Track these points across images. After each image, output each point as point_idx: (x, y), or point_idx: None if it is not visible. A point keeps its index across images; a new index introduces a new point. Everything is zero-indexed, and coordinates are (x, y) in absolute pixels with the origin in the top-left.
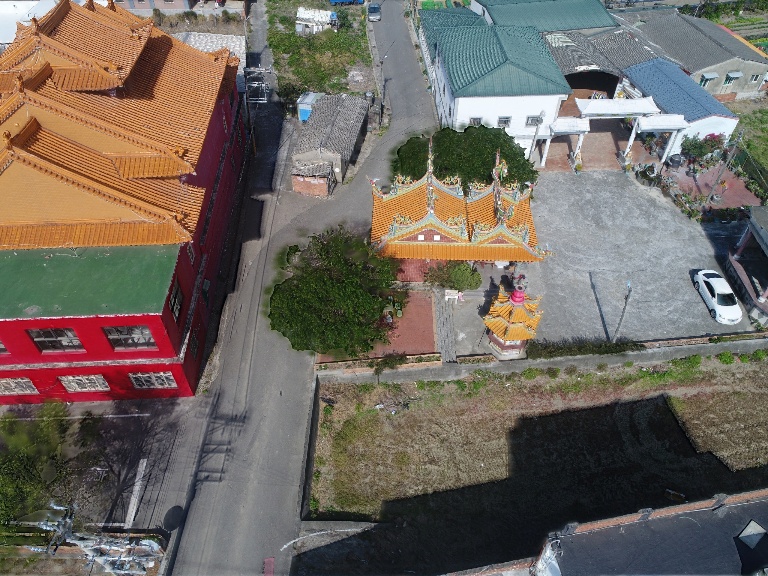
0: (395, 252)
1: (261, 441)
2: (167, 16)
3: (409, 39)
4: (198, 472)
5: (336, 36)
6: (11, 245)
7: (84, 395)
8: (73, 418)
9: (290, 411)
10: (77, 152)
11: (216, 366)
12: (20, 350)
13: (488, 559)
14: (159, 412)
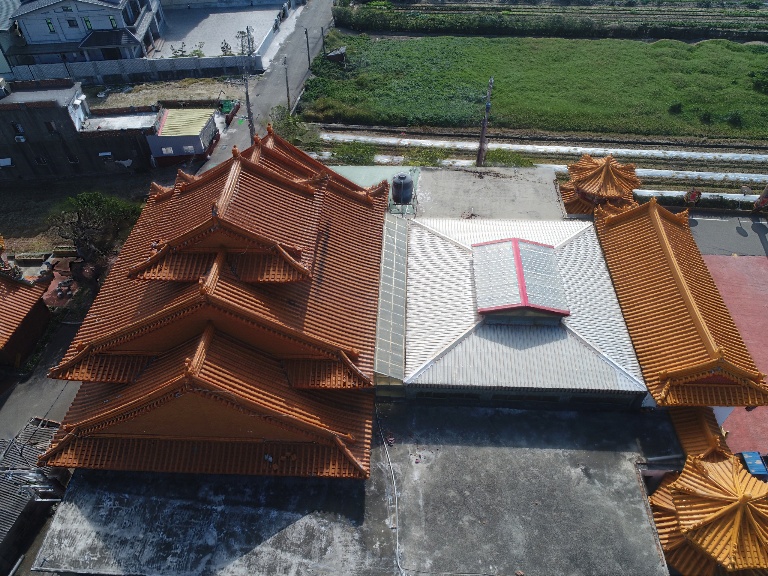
0: (30, 278)
1: None
2: None
3: None
4: None
5: None
6: None
7: None
8: None
9: None
10: None
11: None
12: None
13: (100, 186)
14: None
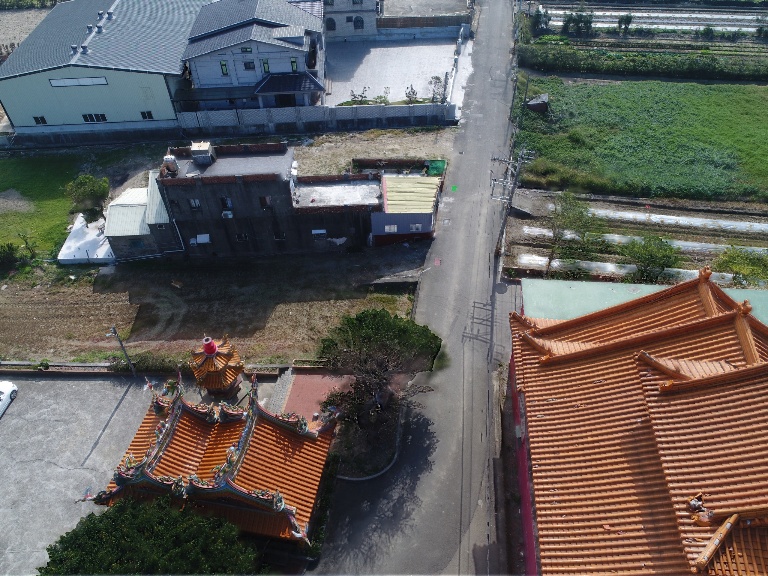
0: None
1: (448, 321)
2: None
3: None
4: (492, 310)
5: None
6: None
7: None
8: None
9: None
10: None
11: (495, 380)
12: None
13: (309, 268)
14: None
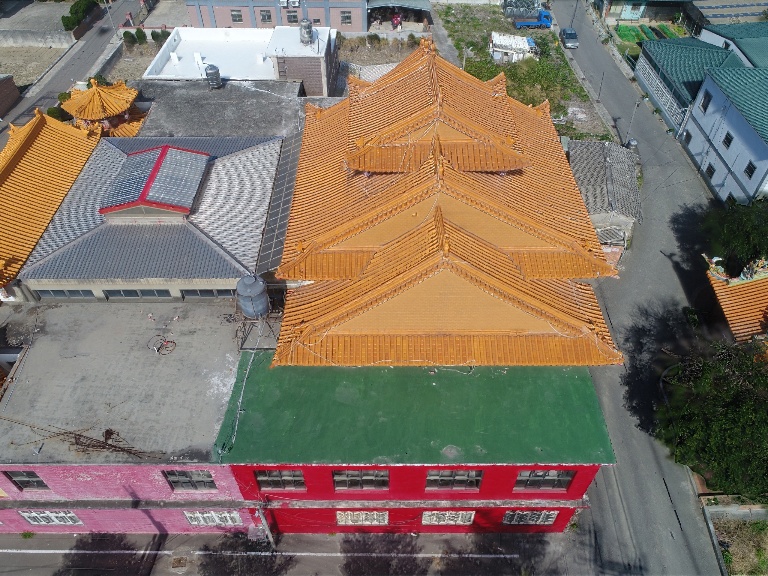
0: None
1: None
2: (347, 39)
3: (619, 70)
4: None
5: (538, 65)
6: (401, 361)
7: (437, 527)
8: (427, 556)
9: (693, 561)
10: (479, 248)
11: None
12: (404, 488)
13: None
14: (528, 553)
